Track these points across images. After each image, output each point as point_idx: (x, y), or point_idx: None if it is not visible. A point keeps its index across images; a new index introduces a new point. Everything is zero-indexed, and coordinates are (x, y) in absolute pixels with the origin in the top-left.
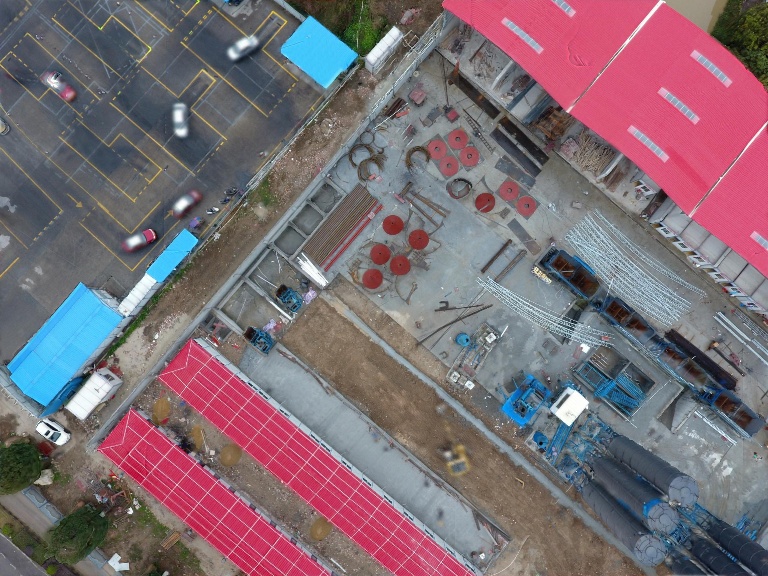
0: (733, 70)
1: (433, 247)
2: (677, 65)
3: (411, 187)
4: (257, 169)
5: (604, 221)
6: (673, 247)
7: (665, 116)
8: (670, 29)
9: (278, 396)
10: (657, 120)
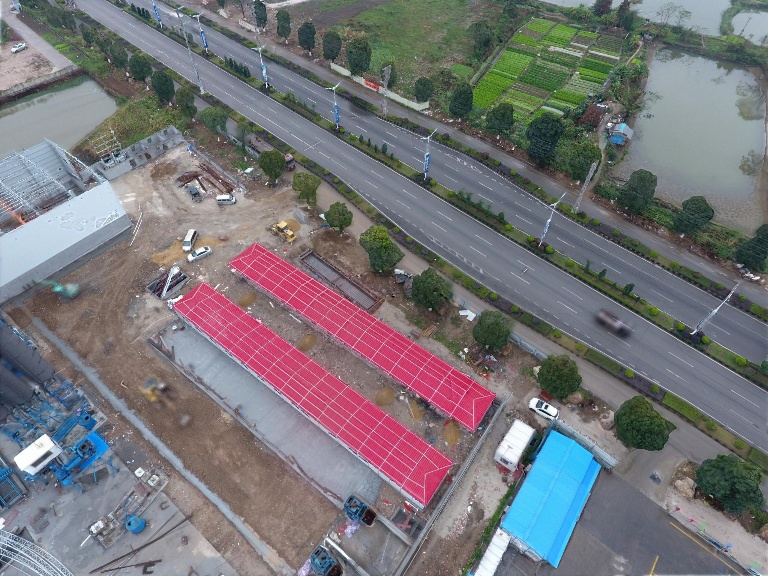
0: None
1: None
2: None
3: None
4: None
5: None
6: None
7: None
8: None
9: (342, 452)
10: None
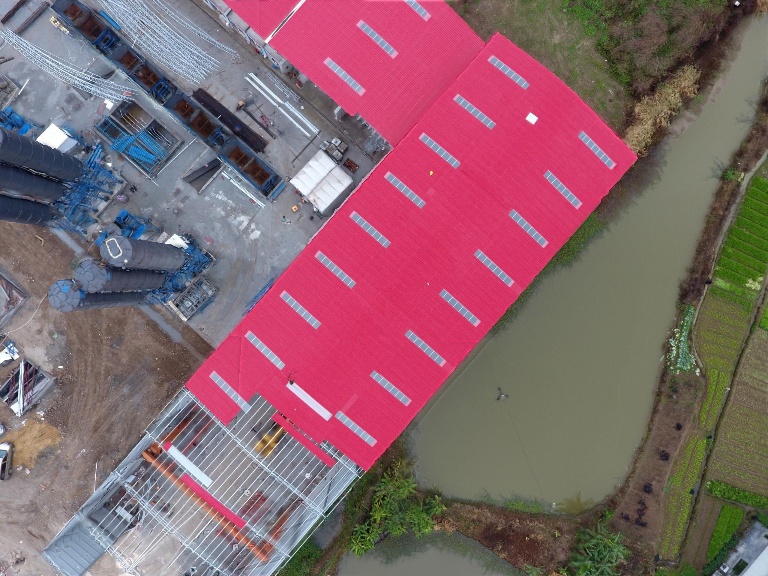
0: None
1: None
2: None
3: None
4: None
5: None
6: (206, 6)
7: None
8: None
9: None
10: None
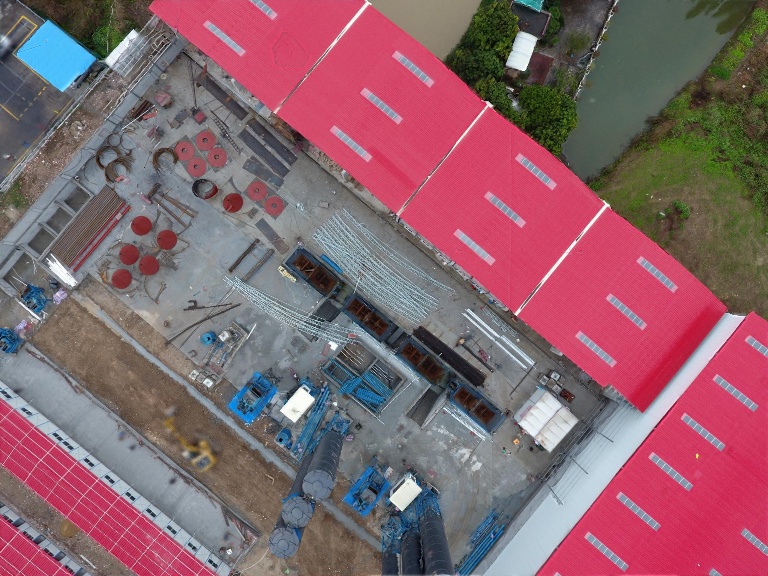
0: (434, 70)
1: (181, 247)
2: (379, 66)
3: (159, 188)
4: (8, 172)
5: (352, 220)
6: (422, 245)
7: (367, 116)
8: (374, 30)
9: (27, 395)
10: (359, 120)
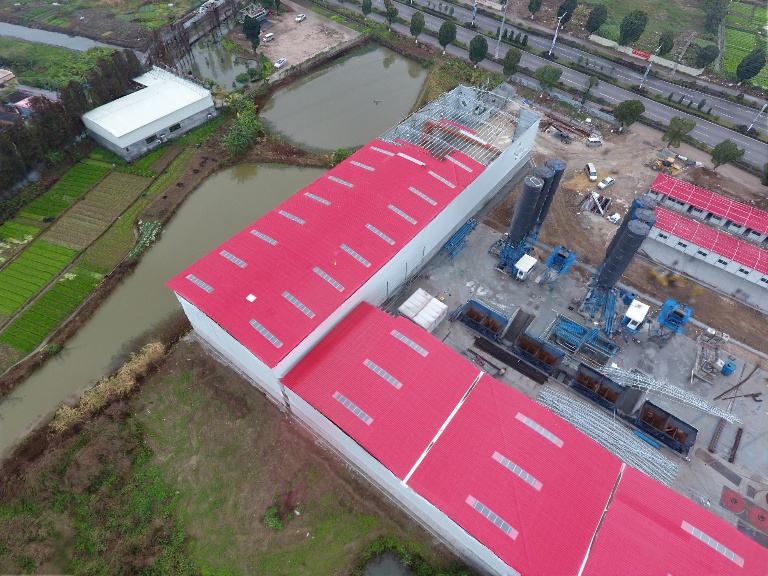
0: None
1: None
2: None
3: None
4: None
5: None
6: None
7: None
8: None
9: None
10: None
